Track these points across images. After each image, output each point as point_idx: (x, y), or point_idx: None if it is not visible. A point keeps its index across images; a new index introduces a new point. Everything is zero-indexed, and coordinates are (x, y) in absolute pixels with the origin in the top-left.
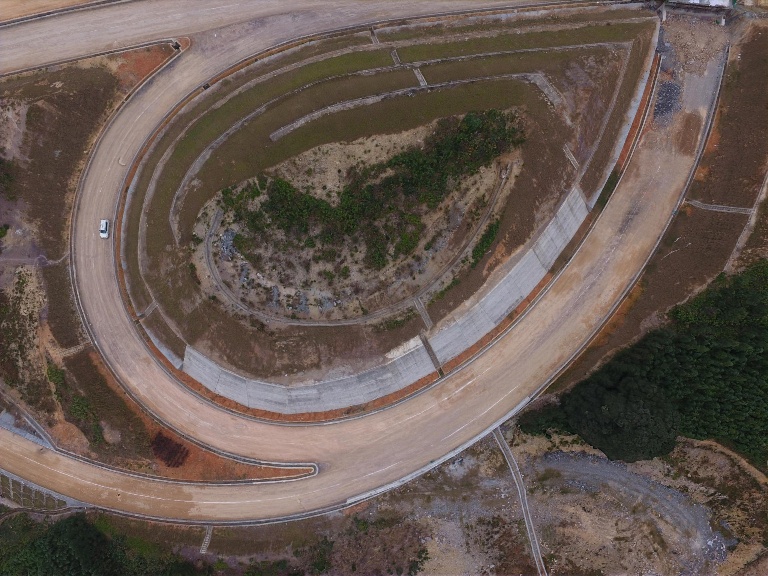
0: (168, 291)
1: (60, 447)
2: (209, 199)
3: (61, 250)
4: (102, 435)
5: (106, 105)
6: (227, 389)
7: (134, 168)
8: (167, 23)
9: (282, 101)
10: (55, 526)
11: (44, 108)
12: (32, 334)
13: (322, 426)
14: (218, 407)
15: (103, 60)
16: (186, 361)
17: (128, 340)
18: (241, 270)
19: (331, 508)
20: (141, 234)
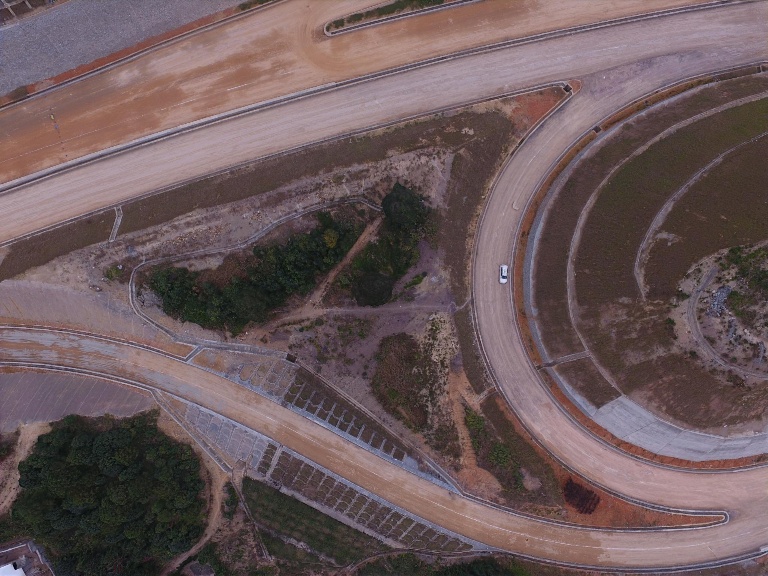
0: (609, 341)
1: (467, 492)
2: (706, 256)
3: (463, 296)
4: (522, 482)
5: (501, 149)
6: (644, 437)
7: (529, 213)
8: (556, 65)
9: (739, 151)
10: (464, 570)
11: (463, 156)
12: (443, 380)
13: (730, 473)
14: (623, 453)
15: (497, 104)
16: (604, 409)
17: (529, 385)
18: (729, 326)
19: (744, 556)
20: (570, 283)
